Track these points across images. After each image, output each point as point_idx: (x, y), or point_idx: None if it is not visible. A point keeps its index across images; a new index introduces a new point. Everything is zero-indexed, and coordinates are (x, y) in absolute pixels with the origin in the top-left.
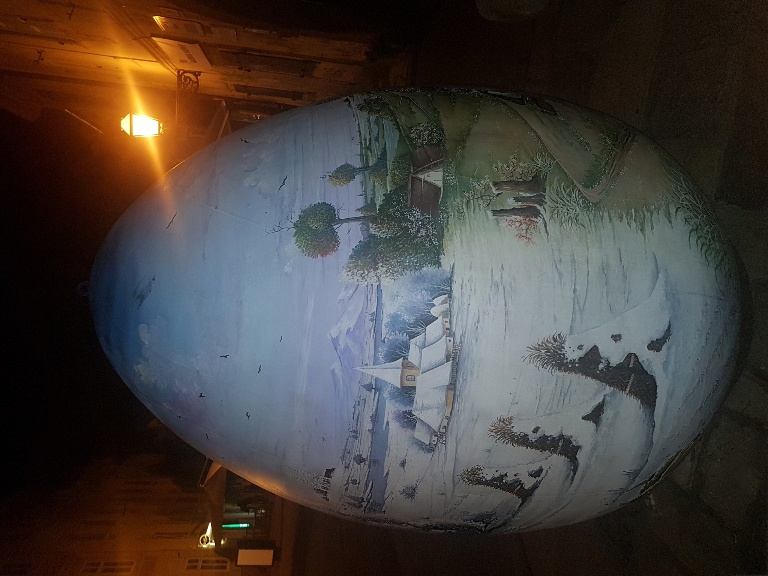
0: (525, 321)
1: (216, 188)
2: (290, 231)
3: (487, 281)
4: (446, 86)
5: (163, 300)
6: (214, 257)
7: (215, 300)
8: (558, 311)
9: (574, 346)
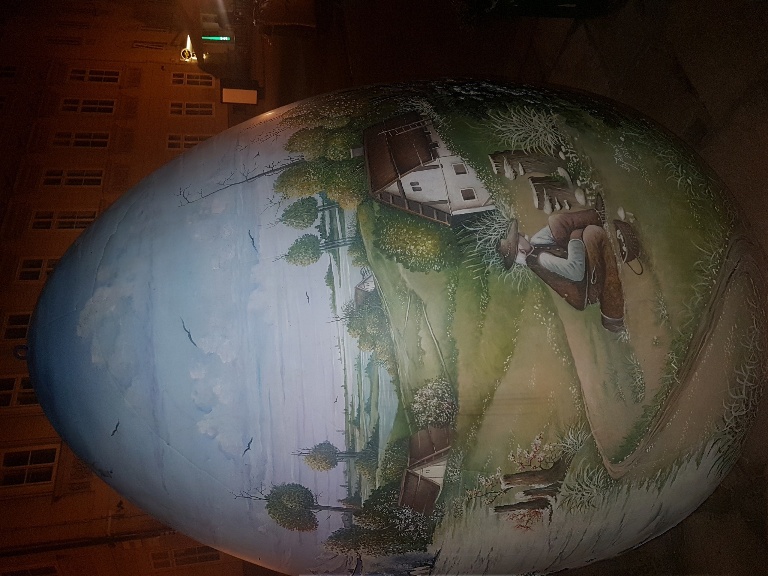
0: (503, 571)
1: (163, 415)
2: (261, 502)
3: (473, 558)
4: (481, 226)
5: (128, 489)
6: (177, 492)
7: (186, 519)
8: (538, 564)
9: (545, 572)
